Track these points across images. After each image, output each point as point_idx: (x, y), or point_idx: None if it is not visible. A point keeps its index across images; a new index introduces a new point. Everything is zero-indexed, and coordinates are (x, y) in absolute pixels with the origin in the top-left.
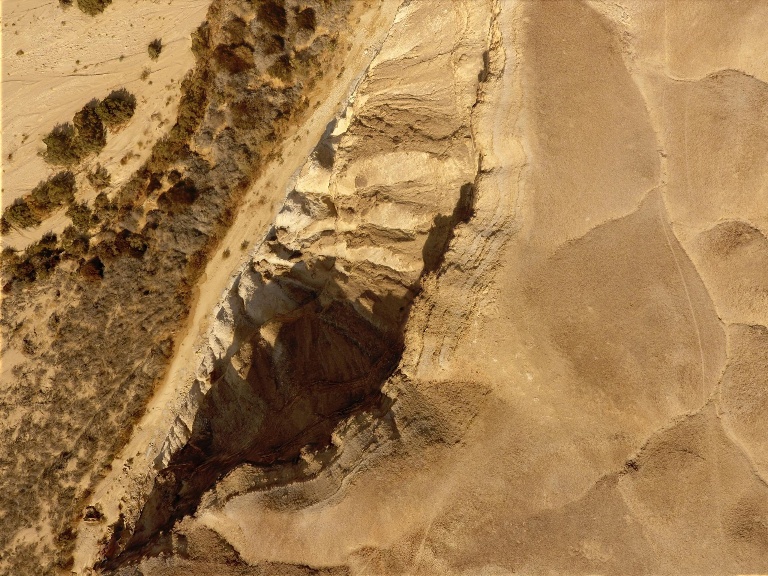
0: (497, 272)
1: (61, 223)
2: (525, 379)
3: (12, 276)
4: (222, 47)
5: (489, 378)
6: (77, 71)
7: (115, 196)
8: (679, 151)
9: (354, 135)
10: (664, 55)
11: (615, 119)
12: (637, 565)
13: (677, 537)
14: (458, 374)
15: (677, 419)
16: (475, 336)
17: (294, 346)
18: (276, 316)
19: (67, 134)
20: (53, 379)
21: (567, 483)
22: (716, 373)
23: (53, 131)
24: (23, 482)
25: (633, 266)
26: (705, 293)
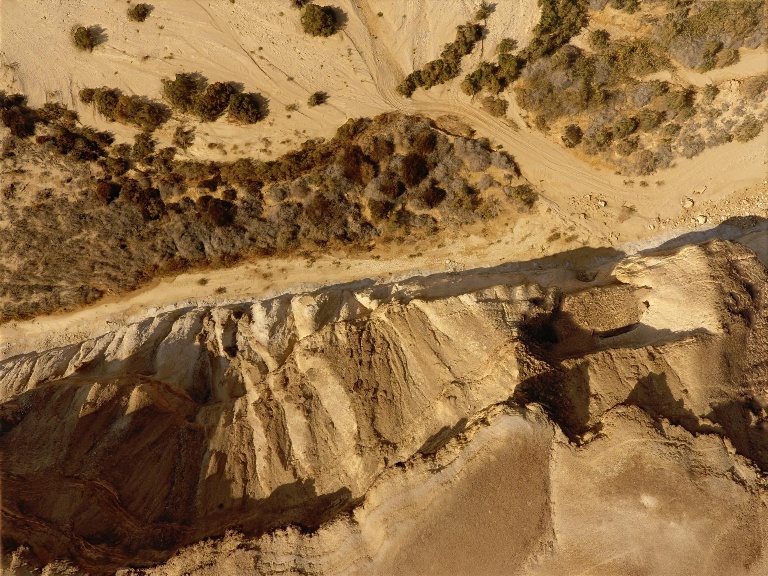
0: None
1: (127, 137)
2: None
3: (54, 135)
4: (358, 151)
5: None
6: (253, 54)
7: (180, 160)
8: None
9: (347, 336)
10: None
11: None
12: None
13: None
14: None
15: None
16: None
17: (136, 433)
18: (160, 388)
19: (198, 86)
20: None
21: None
22: None
23: (192, 73)
24: None
25: None
26: None
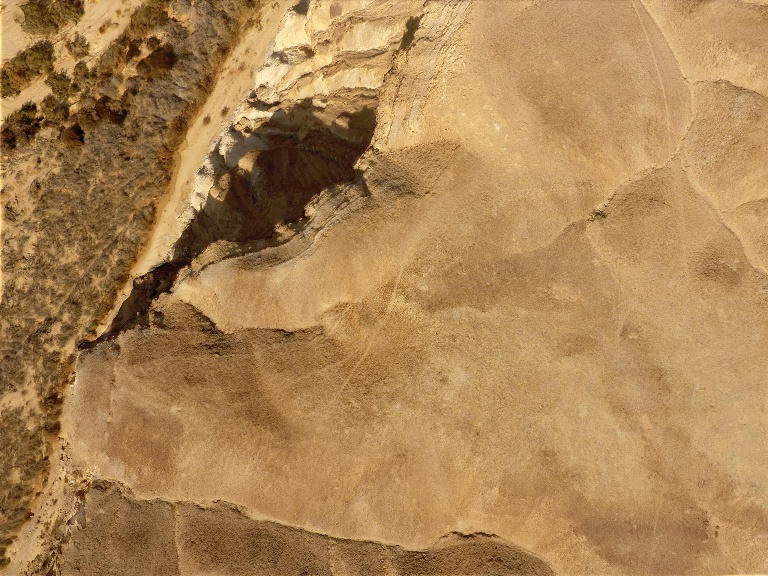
0: (464, 29)
1: (41, 92)
2: (493, 129)
3: None
4: None
5: (458, 133)
6: None
7: (94, 65)
8: None
9: None
10: None
11: None
12: (605, 304)
13: (644, 277)
14: (428, 136)
15: (643, 171)
16: (443, 92)
17: (271, 168)
18: None
19: (45, 3)
20: (35, 245)
21: (535, 228)
22: (681, 129)
23: (31, 1)
24: (8, 348)
25: (598, 25)
26: (670, 53)
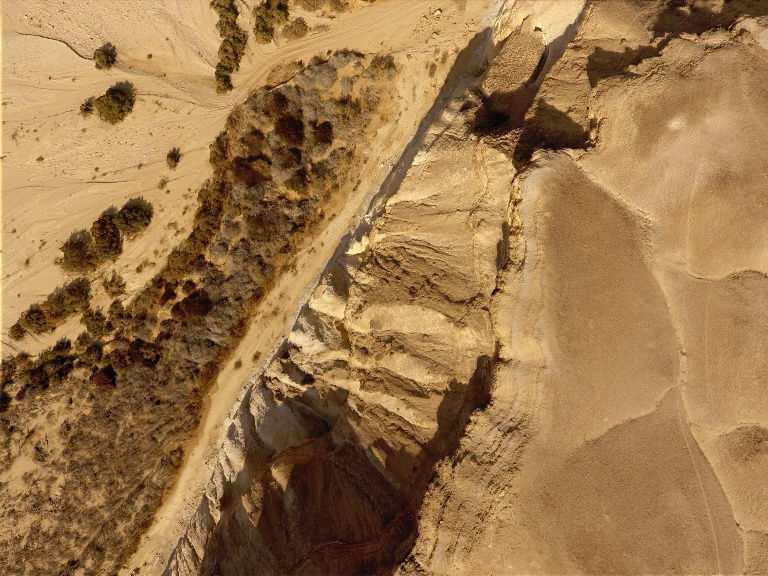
0: (514, 476)
1: (75, 329)
2: None
3: (26, 383)
4: (240, 160)
5: None
6: (96, 178)
7: (130, 303)
8: (699, 351)
9: (370, 275)
10: (685, 253)
11: (635, 317)
12: None
13: None
14: (472, 574)
15: None
16: (490, 540)
17: (305, 494)
18: (288, 452)
19: (84, 241)
20: (63, 487)
21: None
22: None
23: (70, 237)
24: None
25: (651, 471)
26: (723, 498)
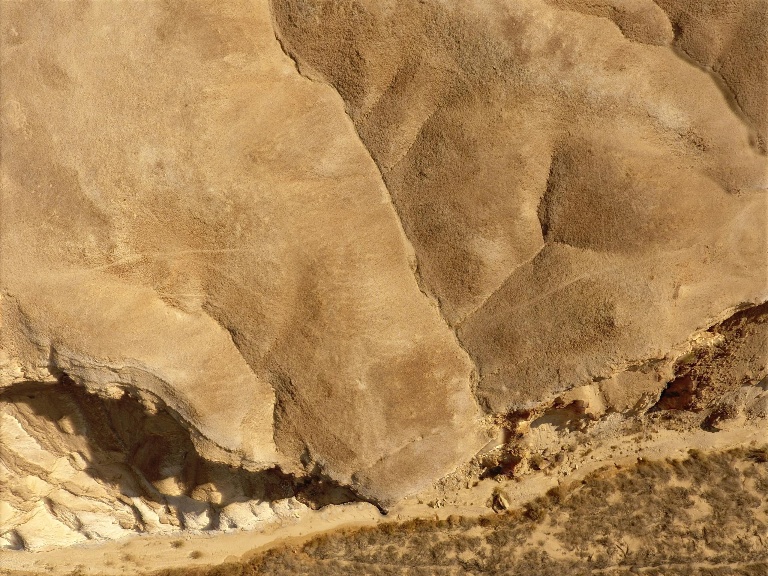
0: None
1: None
2: None
3: None
4: None
5: None
6: None
7: None
8: None
9: None
10: None
11: None
12: (3, 75)
13: None
14: None
15: None
16: None
17: (153, 461)
18: None
19: None
20: None
21: None
22: None
23: None
24: None
25: None
26: None
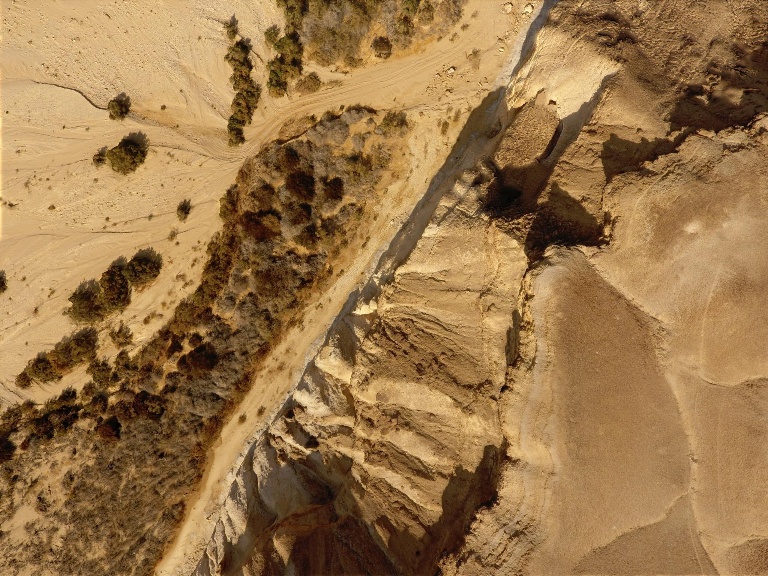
0: None
1: (82, 379)
2: None
3: (30, 433)
4: (250, 215)
5: None
6: (106, 228)
7: (136, 354)
8: (710, 459)
9: (377, 346)
10: (698, 358)
11: (646, 422)
12: None
13: None
14: None
15: None
16: None
17: (307, 569)
18: (290, 521)
19: (93, 291)
20: (64, 538)
21: None
22: None
23: (79, 287)
24: None
25: None
26: None
